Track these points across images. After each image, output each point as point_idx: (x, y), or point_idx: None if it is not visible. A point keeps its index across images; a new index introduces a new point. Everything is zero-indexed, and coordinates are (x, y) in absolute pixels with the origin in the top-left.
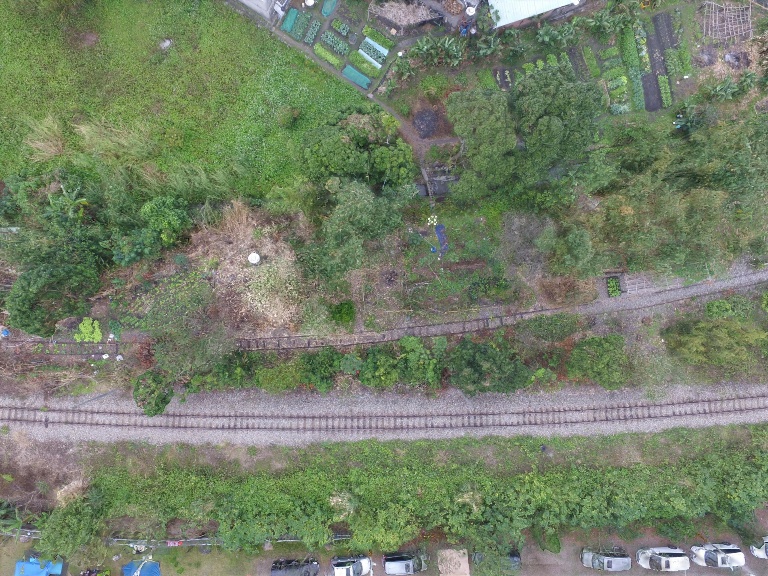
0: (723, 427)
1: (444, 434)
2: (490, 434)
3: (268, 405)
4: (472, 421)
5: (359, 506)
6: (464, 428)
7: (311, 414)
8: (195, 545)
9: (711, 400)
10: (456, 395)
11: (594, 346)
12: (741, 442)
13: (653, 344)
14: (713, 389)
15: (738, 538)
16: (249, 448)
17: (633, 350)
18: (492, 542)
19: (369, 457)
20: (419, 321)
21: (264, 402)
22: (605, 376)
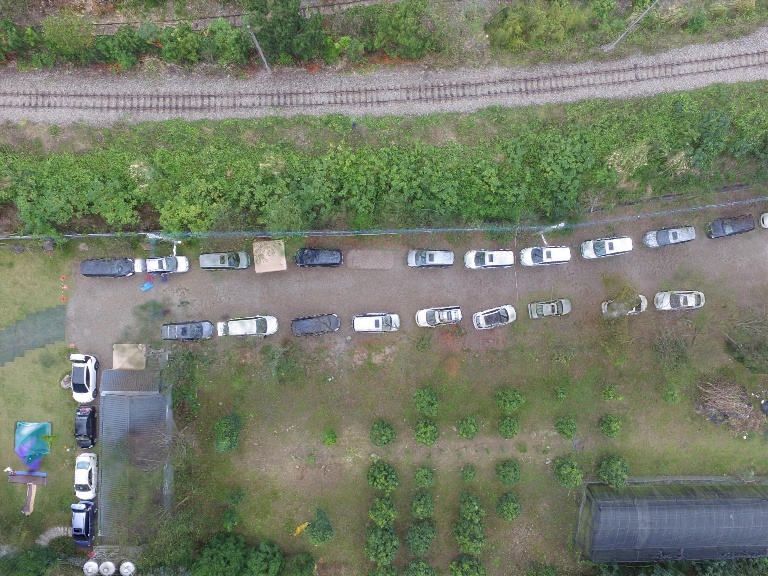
0: (540, 107)
1: (253, 113)
2: (300, 113)
3: (71, 84)
4: (282, 101)
5: (159, 177)
6: (273, 107)
7: (115, 93)
8: (7, 244)
9: (527, 79)
10: (266, 76)
11: (394, 3)
12: (556, 118)
13: (477, 39)
14: (530, 69)
15: (570, 243)
16: (51, 127)
17: (456, 45)
18: (294, 208)
19: (175, 136)
20: (233, 10)
21: (67, 82)
22: (402, 26)
